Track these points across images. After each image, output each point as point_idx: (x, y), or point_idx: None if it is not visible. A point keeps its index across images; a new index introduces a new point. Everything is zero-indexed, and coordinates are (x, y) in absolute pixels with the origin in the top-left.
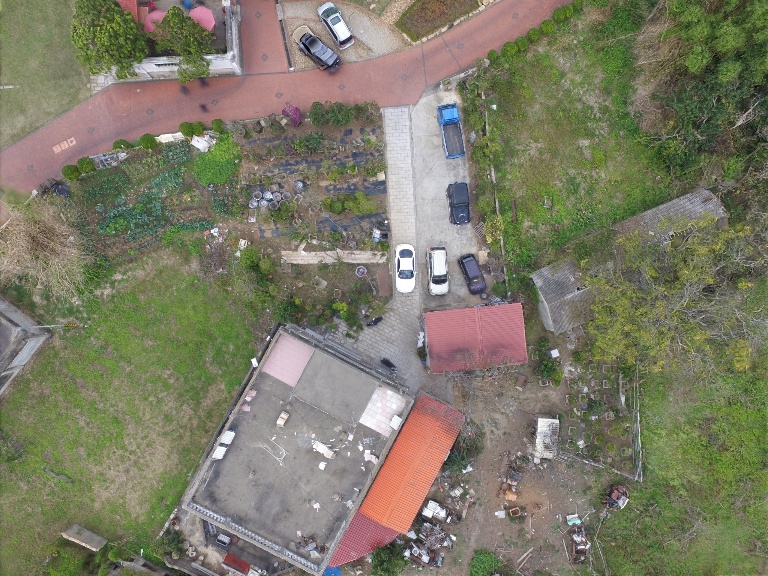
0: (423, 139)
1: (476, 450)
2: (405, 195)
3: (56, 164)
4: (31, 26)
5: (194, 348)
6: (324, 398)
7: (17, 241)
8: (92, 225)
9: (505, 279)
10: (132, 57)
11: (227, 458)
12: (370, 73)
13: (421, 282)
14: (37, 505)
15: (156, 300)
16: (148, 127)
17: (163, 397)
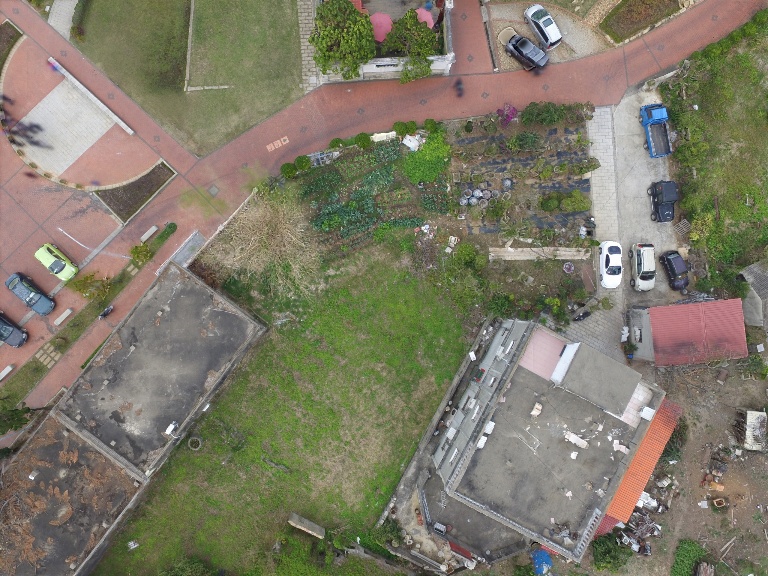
0: (625, 138)
1: (681, 442)
2: (608, 193)
3: (270, 162)
4: (246, 28)
5: (406, 342)
6: (591, 389)
7: (260, 237)
8: (306, 222)
9: (707, 275)
10: (365, 58)
11: (484, 447)
12: (573, 74)
13: (624, 278)
14: (256, 494)
15: (368, 295)
16: (359, 126)
17: (376, 390)
